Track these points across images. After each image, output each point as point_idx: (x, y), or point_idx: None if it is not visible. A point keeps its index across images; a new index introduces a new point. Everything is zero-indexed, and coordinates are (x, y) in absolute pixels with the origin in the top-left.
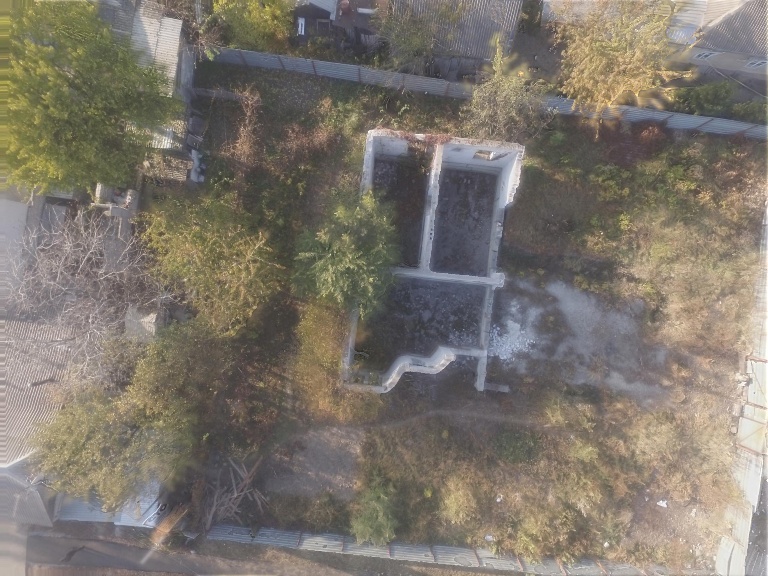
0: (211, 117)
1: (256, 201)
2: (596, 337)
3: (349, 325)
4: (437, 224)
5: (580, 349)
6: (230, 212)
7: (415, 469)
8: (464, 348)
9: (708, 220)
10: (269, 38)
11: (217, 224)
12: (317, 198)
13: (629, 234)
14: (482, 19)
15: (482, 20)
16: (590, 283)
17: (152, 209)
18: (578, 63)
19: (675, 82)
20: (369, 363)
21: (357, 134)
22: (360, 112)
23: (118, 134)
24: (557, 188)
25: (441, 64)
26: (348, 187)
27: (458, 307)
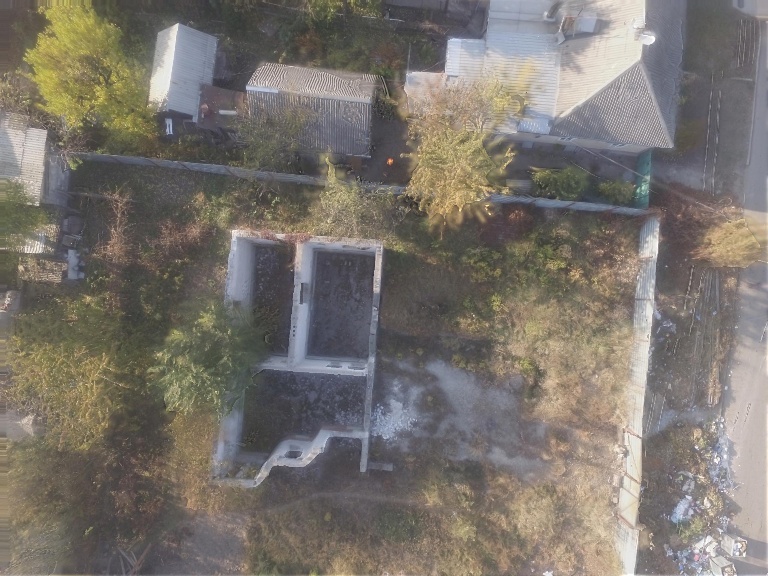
0: (89, 215)
1: (134, 296)
2: (477, 413)
3: None
4: (319, 307)
5: (462, 426)
6: (98, 316)
7: (300, 551)
8: (347, 429)
9: (580, 297)
10: (140, 138)
11: (65, 344)
12: (195, 290)
13: (501, 315)
14: (336, 121)
15: (336, 121)
16: (468, 362)
17: (31, 309)
18: None
19: (545, 161)
20: (255, 446)
21: (232, 226)
22: (233, 205)
23: None
24: (430, 272)
25: (309, 157)
26: None
27: (343, 387)
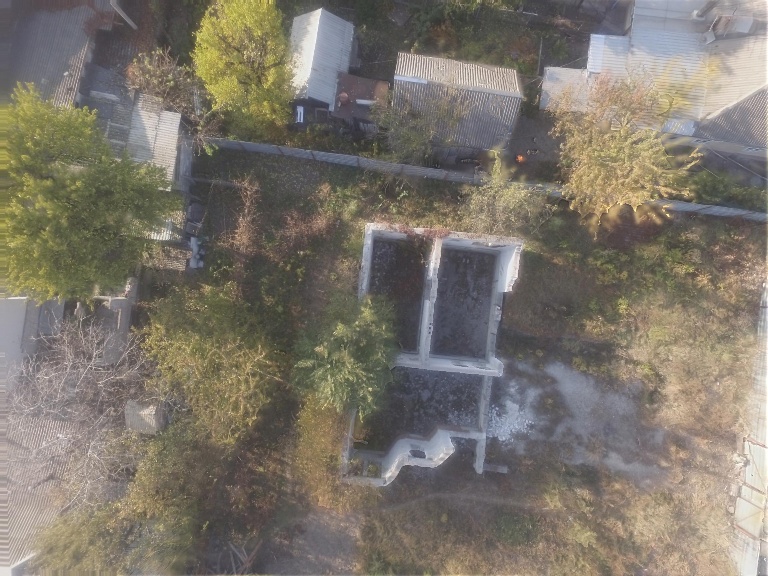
0: (210, 202)
1: (255, 287)
2: (594, 418)
3: (348, 419)
4: (436, 304)
5: (578, 430)
6: (229, 306)
7: (414, 552)
8: (463, 429)
9: (706, 303)
10: (268, 125)
11: (216, 334)
12: (316, 283)
13: (627, 318)
14: (481, 114)
15: (481, 115)
16: (588, 365)
17: (151, 297)
18: (576, 161)
19: (673, 164)
20: (368, 444)
21: (356, 219)
22: (359, 197)
23: (117, 247)
24: (556, 272)
25: (440, 151)
26: (347, 272)
27: (457, 386)
